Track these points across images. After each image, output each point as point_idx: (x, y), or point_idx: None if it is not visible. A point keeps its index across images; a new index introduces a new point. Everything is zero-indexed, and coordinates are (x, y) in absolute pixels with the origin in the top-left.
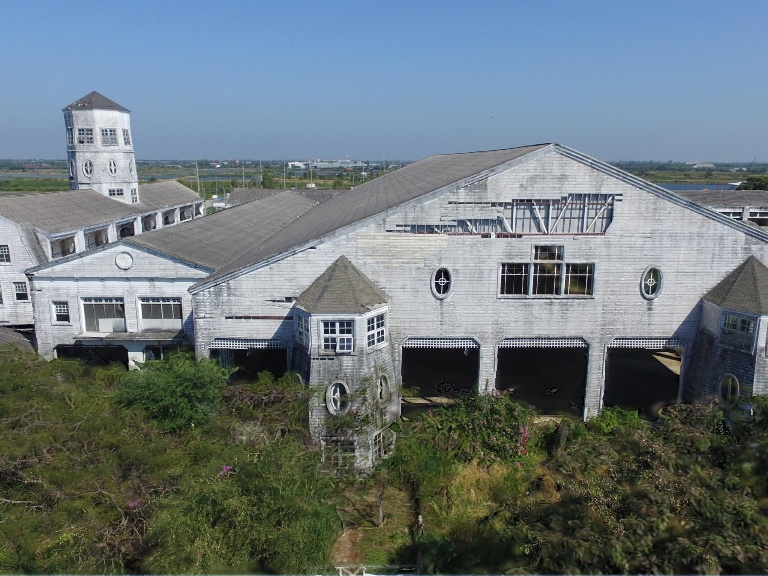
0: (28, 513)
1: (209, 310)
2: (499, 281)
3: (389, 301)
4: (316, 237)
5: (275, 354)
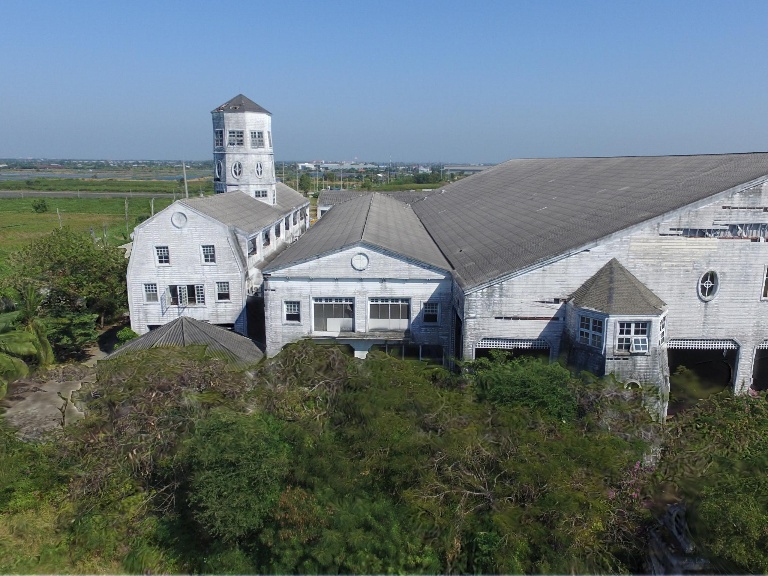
0: (506, 504)
1: (480, 310)
2: (764, 284)
3: None
4: (592, 240)
5: (536, 354)
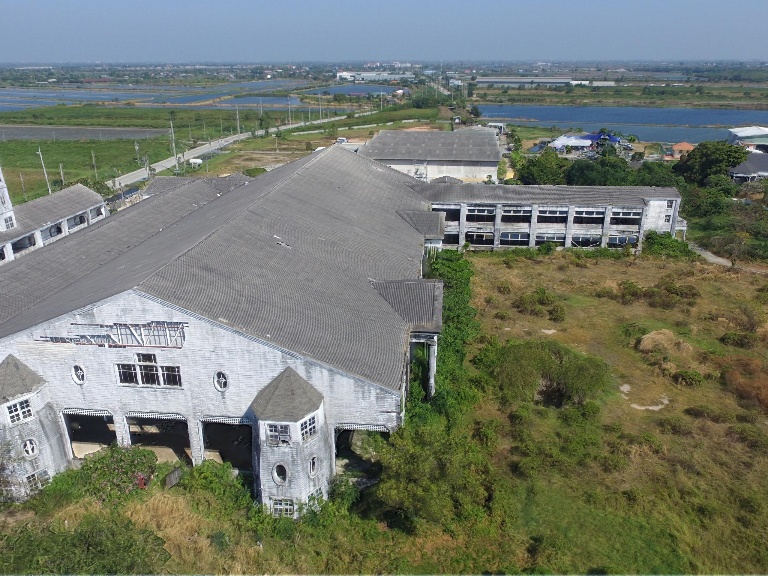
0: None
1: None
2: (117, 375)
3: (47, 384)
4: None
5: None
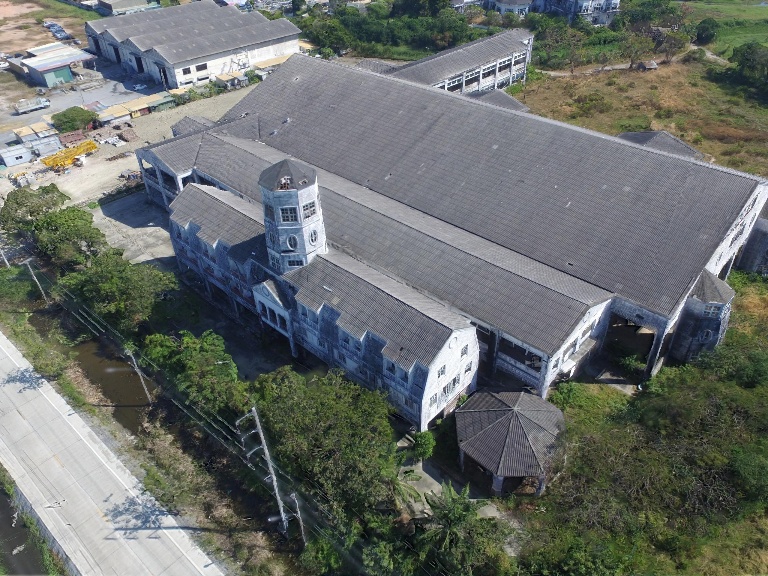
0: None
1: None
2: None
3: None
4: None
5: None
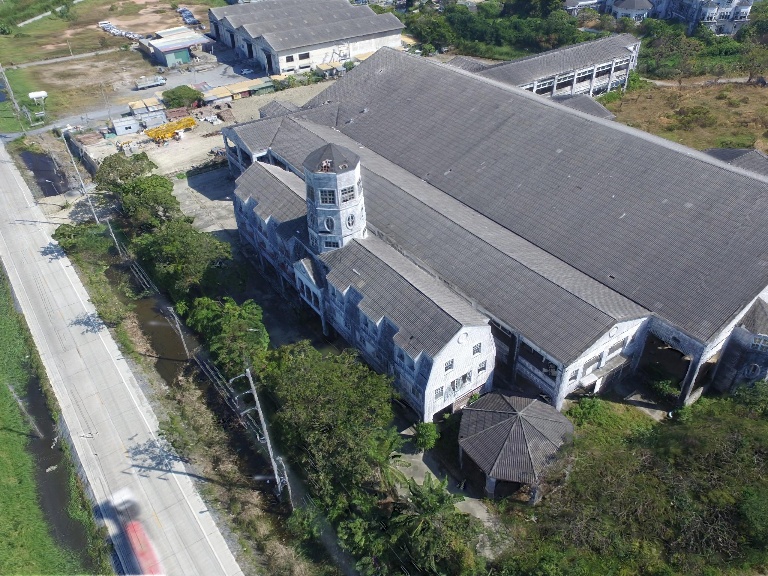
0: None
1: None
2: None
3: None
4: None
5: None
